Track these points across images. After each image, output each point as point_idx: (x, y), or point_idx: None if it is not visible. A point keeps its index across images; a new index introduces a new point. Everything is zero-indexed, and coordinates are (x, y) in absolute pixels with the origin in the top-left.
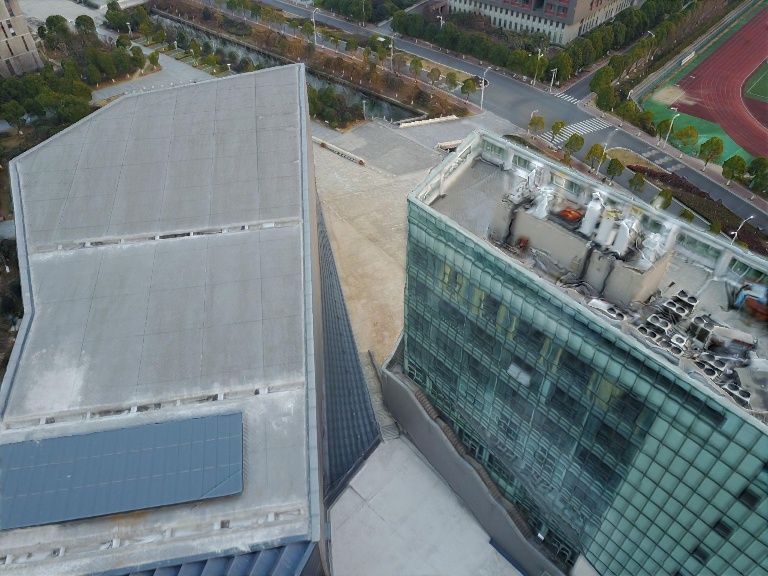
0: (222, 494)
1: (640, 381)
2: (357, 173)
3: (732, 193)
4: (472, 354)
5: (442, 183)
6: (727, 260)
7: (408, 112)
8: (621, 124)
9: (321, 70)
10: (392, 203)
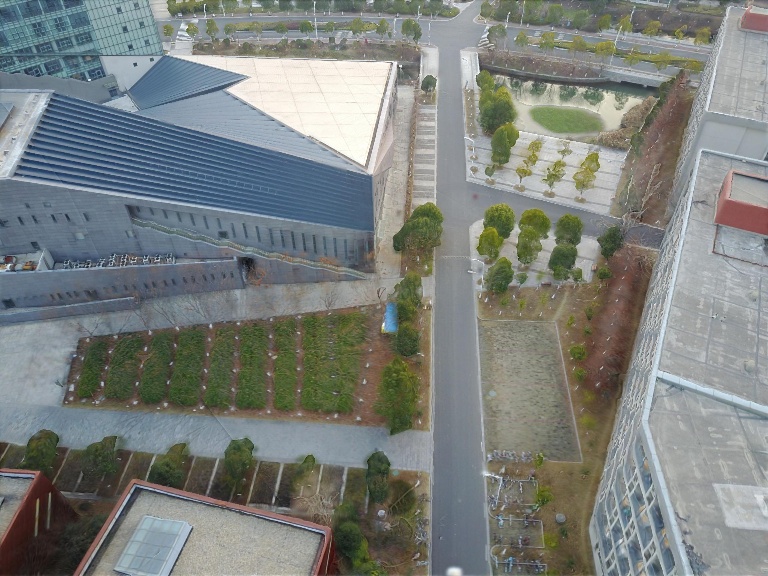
0: (11, 107)
1: None
2: None
3: None
4: None
5: None
6: None
7: None
8: None
9: None
10: None
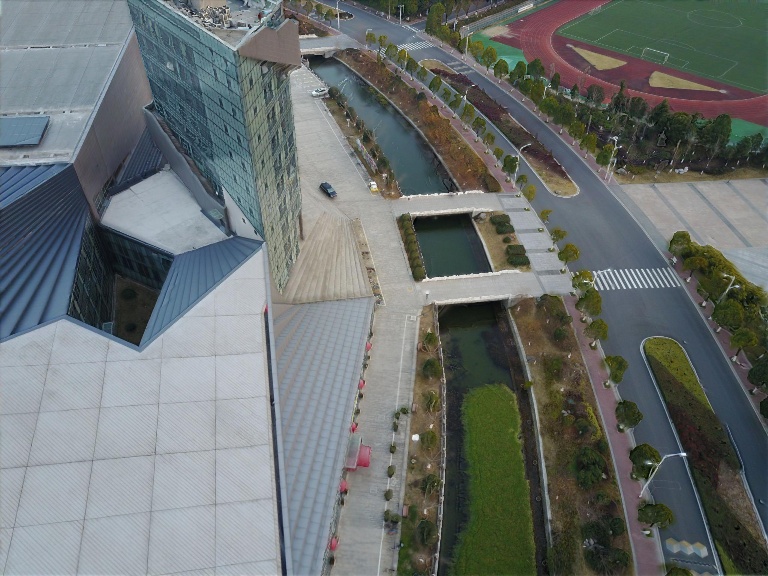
0: (26, 143)
1: (184, 33)
2: None
3: (499, 88)
4: (162, 69)
5: None
6: (263, 1)
7: None
8: (441, 45)
9: None
10: None
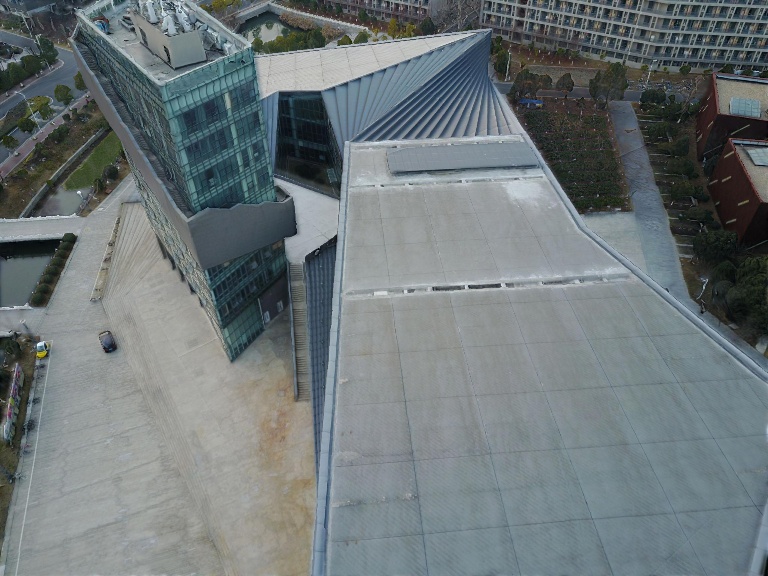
0: (397, 148)
1: None
2: None
3: None
4: None
5: None
6: None
7: None
8: None
9: None
10: None
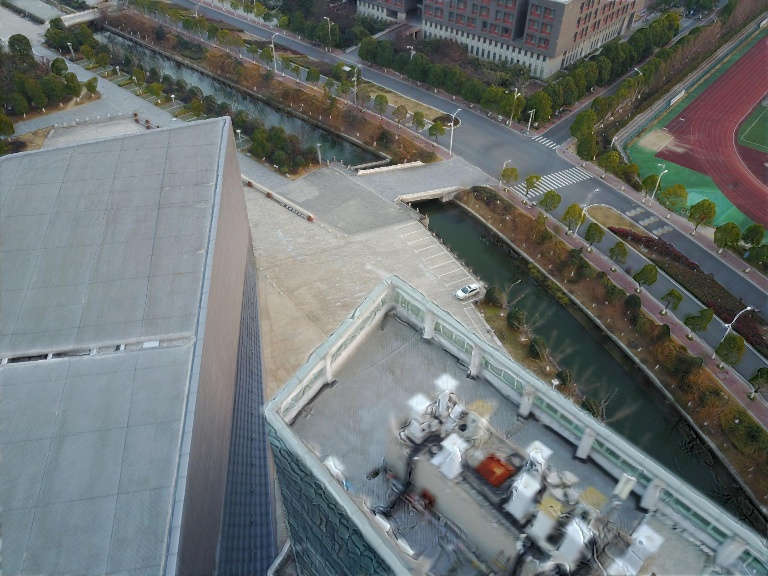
0: None
1: None
2: (304, 231)
3: (725, 263)
4: None
5: (330, 367)
6: (737, 551)
7: (370, 154)
8: (603, 175)
9: (278, 102)
10: (340, 271)
